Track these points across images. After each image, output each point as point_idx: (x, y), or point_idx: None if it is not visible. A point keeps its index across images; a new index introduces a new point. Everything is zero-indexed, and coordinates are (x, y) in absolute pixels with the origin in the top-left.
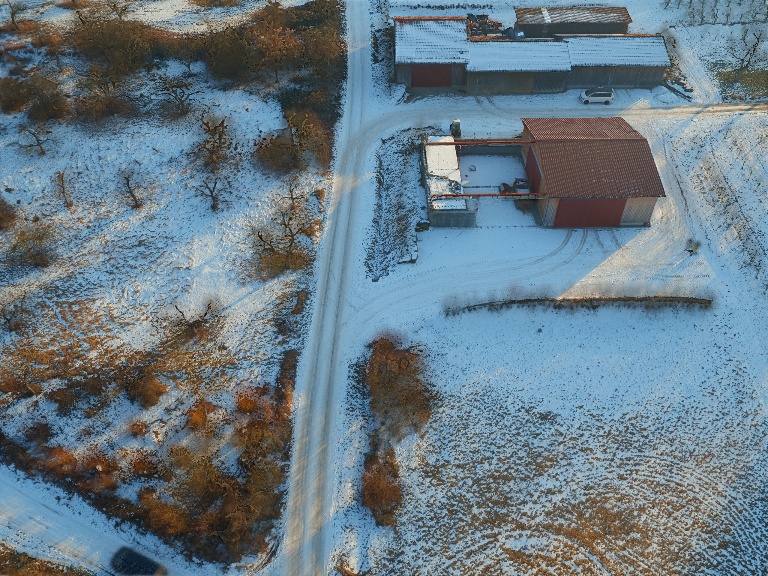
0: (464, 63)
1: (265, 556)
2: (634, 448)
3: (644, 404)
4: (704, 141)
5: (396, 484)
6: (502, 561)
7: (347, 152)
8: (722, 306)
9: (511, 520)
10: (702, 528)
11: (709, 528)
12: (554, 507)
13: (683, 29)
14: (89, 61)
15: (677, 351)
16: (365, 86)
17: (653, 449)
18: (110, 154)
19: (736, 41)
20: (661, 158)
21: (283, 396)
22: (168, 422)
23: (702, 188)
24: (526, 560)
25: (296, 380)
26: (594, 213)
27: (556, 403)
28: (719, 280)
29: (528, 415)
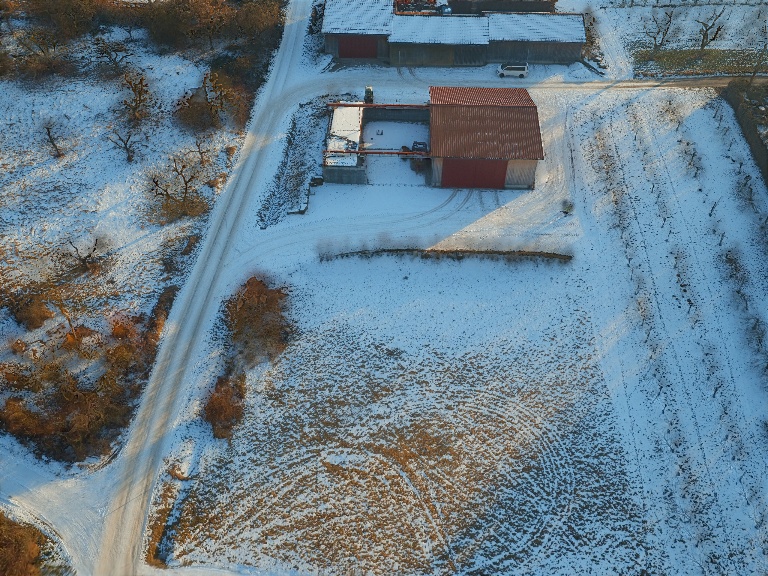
0: (386, 35)
1: (107, 458)
2: (467, 383)
3: (487, 346)
4: (605, 114)
5: (240, 404)
6: (319, 473)
7: (264, 114)
8: (582, 262)
9: (337, 439)
10: (511, 454)
11: (518, 454)
12: (379, 430)
13: (612, 10)
14: (40, 25)
15: (529, 300)
16: (295, 55)
17: (484, 385)
18: (43, 109)
19: (661, 22)
20: (560, 128)
21: (154, 324)
22: (47, 343)
23: (592, 156)
24: (341, 473)
25: (170, 312)
26: (478, 174)
27: (405, 341)
28: (586, 239)
29: (376, 351)
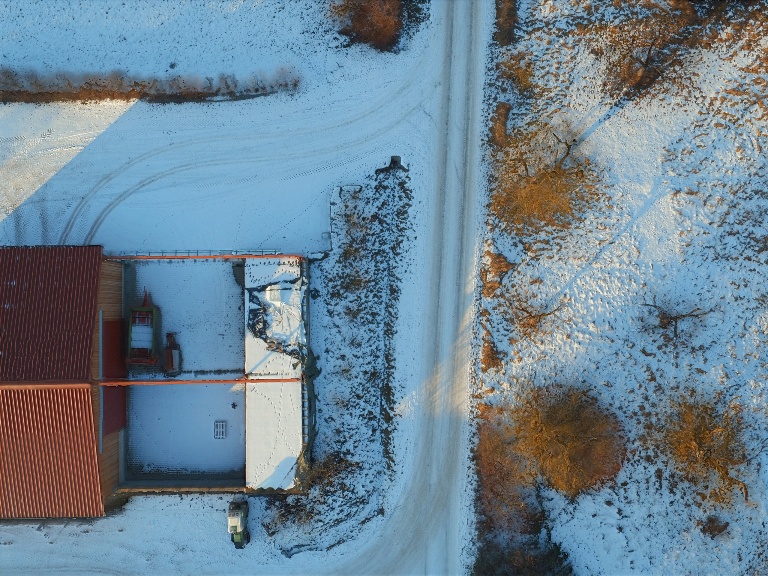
0: None
1: None
2: None
3: None
4: None
5: None
6: None
7: (449, 475)
8: None
9: None
10: None
11: None
12: None
13: None
14: None
15: None
16: None
17: None
18: None
19: None
20: None
21: None
22: None
23: None
24: None
25: None
26: None
27: None
28: None
29: None
